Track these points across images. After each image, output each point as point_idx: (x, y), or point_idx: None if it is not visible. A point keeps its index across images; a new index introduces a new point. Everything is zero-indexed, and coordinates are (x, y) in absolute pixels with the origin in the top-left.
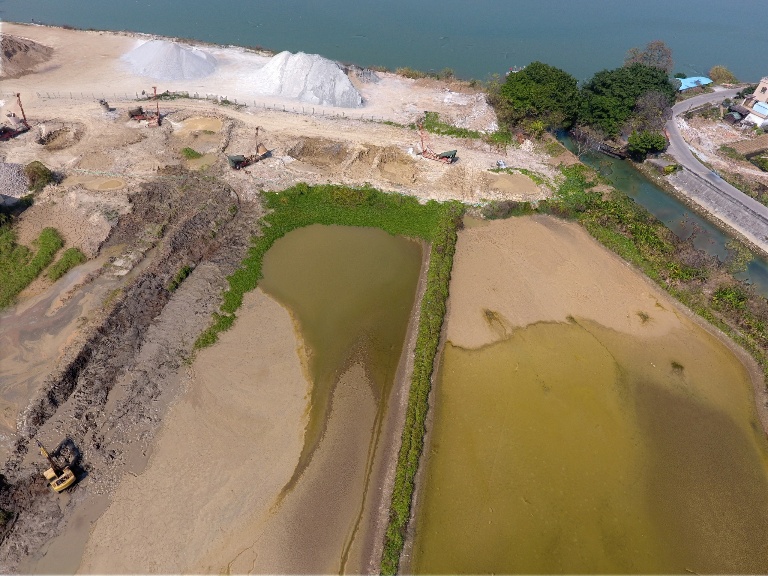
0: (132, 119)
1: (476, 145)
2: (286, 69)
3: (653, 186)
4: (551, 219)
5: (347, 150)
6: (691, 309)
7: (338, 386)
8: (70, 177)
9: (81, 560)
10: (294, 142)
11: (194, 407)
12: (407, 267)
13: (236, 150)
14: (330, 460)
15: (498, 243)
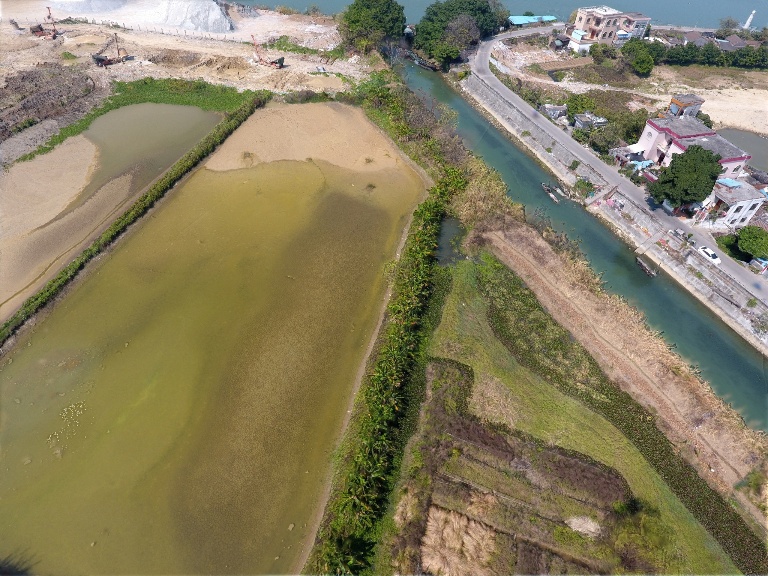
0: (34, 35)
1: (311, 58)
2: (172, 3)
3: (447, 88)
4: (341, 105)
5: (200, 59)
6: (409, 157)
7: (107, 185)
8: None
9: None
10: (157, 52)
11: None
12: (203, 128)
13: (107, 56)
14: (77, 217)
15: (285, 117)
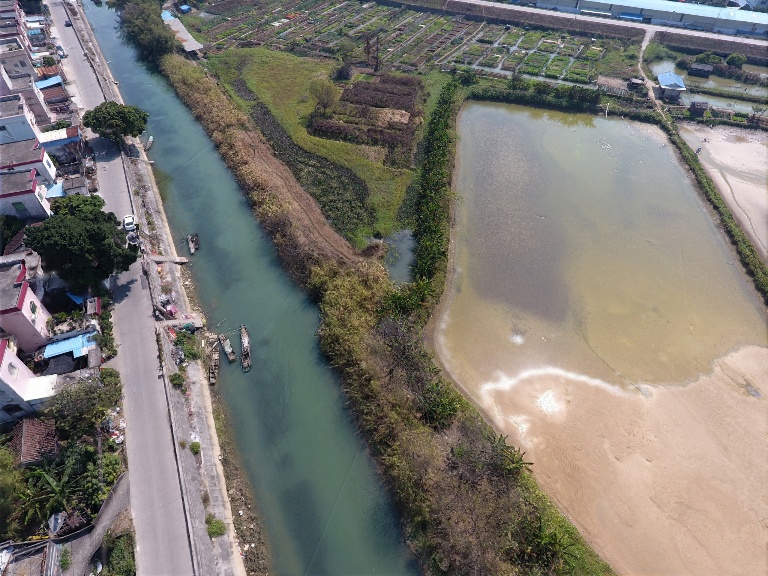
0: None
1: None
2: None
3: None
4: None
5: None
6: None
7: None
8: None
9: None
10: None
11: None
12: None
13: None
14: None
15: None
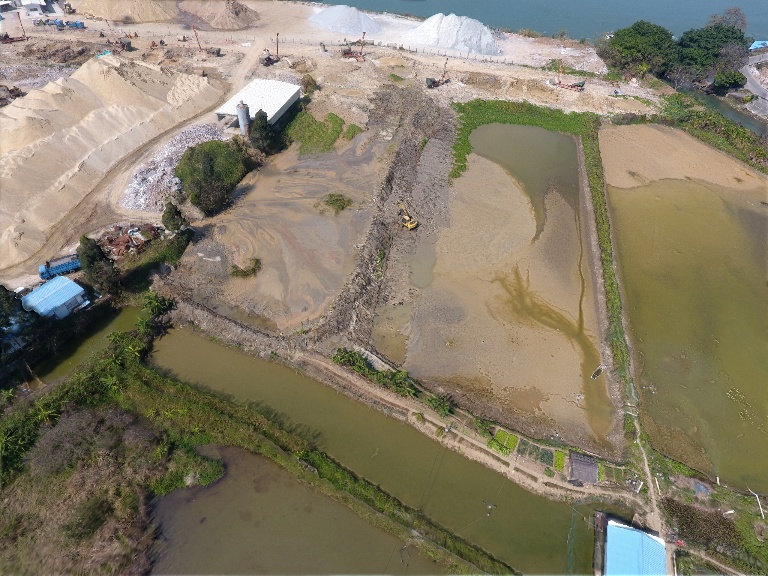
0: (343, 57)
1: (595, 81)
2: (441, 26)
3: (734, 111)
4: (661, 127)
5: (501, 81)
6: None
7: (546, 200)
8: (324, 88)
9: (436, 256)
10: (462, 74)
11: (464, 203)
12: (567, 148)
13: (424, 78)
14: (555, 229)
15: (627, 138)
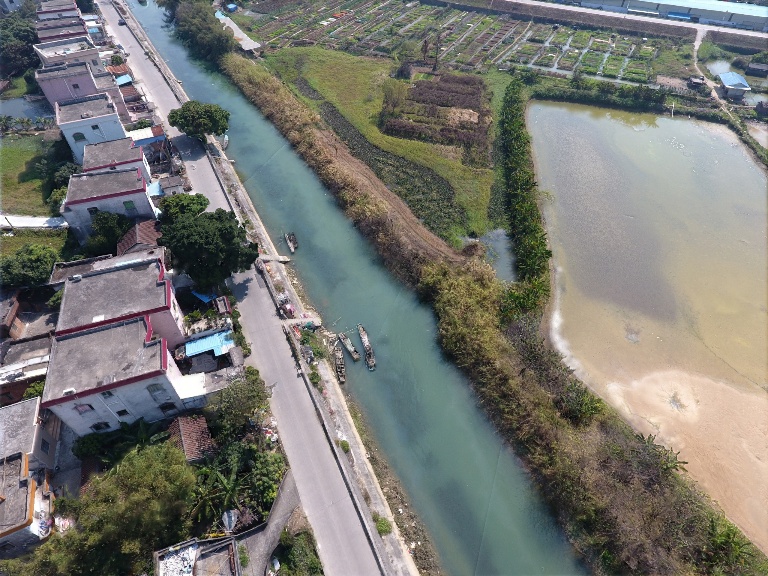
0: None
1: None
2: None
3: None
4: None
5: None
6: None
7: None
8: None
9: None
10: None
11: None
12: None
13: None
14: None
15: None
